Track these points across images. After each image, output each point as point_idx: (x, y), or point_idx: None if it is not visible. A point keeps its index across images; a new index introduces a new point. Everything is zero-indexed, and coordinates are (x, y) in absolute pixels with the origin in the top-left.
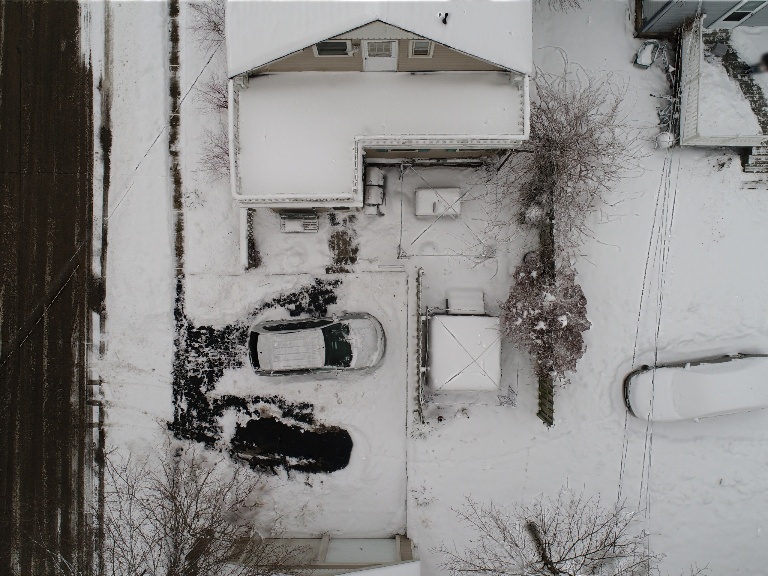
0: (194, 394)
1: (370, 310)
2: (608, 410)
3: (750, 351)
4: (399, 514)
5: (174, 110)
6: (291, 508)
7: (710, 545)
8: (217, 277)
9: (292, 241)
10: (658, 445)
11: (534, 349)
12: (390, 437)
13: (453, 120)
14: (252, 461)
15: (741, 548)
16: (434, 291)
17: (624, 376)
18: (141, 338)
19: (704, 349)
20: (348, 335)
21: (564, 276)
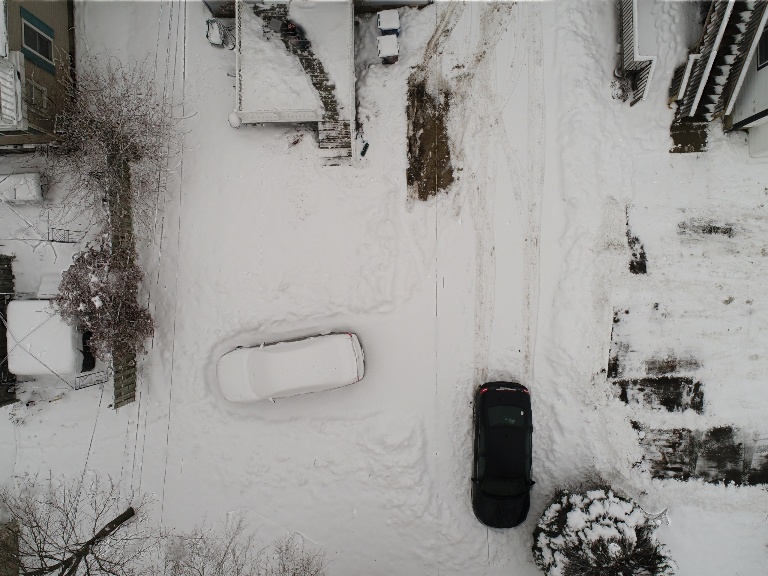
0: None
1: None
2: (202, 392)
3: (343, 330)
4: None
5: None
6: None
7: (306, 527)
8: None
9: None
10: (253, 427)
11: None
12: (2, 424)
13: None
14: None
15: (338, 530)
16: (30, 277)
17: None
18: None
19: (297, 329)
20: None
21: None
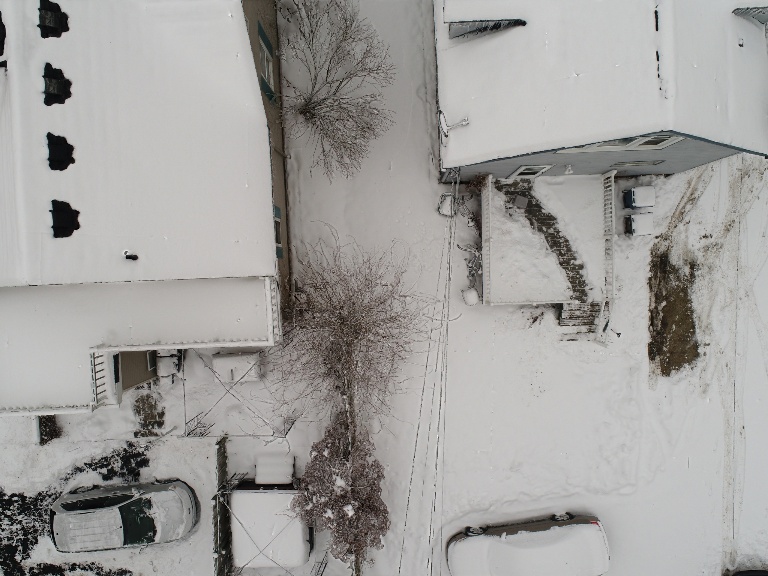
0: (9, 563)
1: (181, 475)
2: None
3: (578, 510)
4: None
5: None
6: None
7: None
8: (21, 447)
9: None
10: None
11: None
12: None
13: (203, 319)
14: None
15: None
16: (243, 456)
17: (447, 539)
18: None
19: (529, 509)
20: (150, 509)
21: None
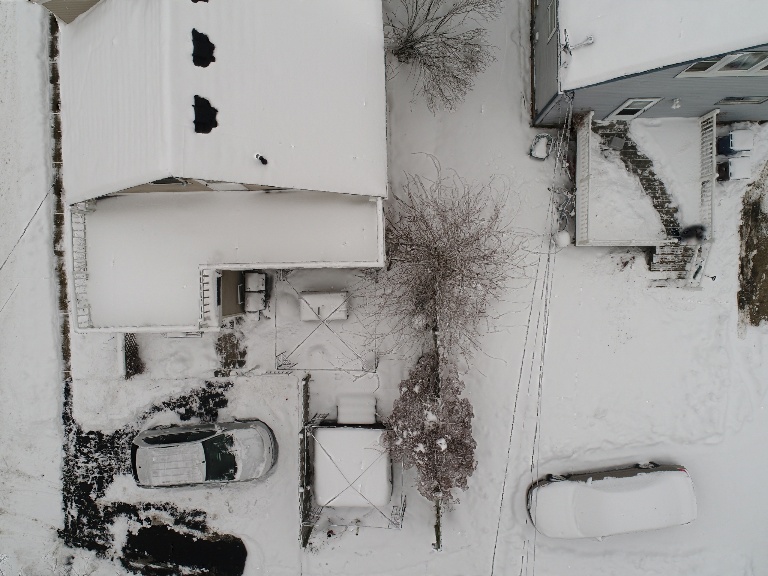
0: (84, 501)
1: (260, 415)
2: (510, 523)
3: (662, 460)
4: None
5: (58, 208)
6: None
7: None
8: (102, 383)
9: (177, 345)
10: (564, 560)
11: (419, 468)
12: (284, 547)
13: (309, 242)
14: (144, 570)
15: None
16: (324, 397)
17: (527, 486)
18: (29, 444)
19: (612, 457)
20: (232, 446)
21: (451, 389)
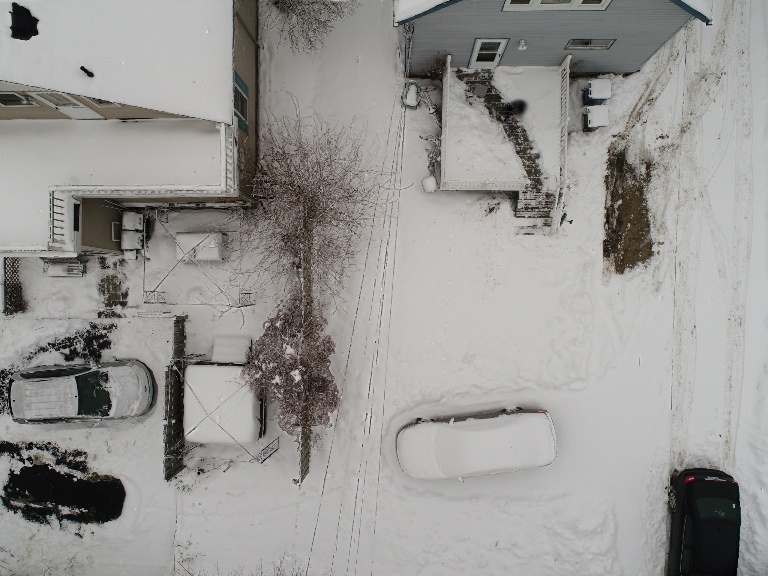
0: None
1: (141, 356)
2: (378, 465)
3: (529, 405)
4: (170, 568)
5: None
6: (60, 559)
7: None
8: None
9: (60, 285)
10: (431, 503)
11: None
12: (161, 488)
13: (161, 169)
14: (24, 509)
15: None
16: (202, 338)
17: (398, 429)
18: None
19: (480, 402)
20: (107, 383)
21: None
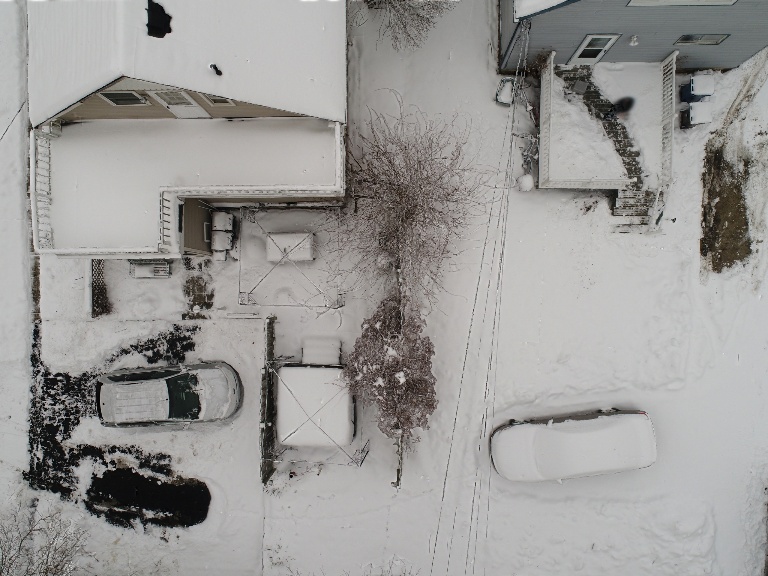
0: (50, 443)
1: (227, 358)
2: (472, 467)
3: (625, 406)
4: (257, 572)
5: None
6: (146, 564)
7: None
8: (70, 323)
9: (145, 286)
10: (526, 505)
11: (379, 405)
12: (248, 491)
13: (270, 169)
14: (108, 513)
15: None
16: (290, 339)
17: (490, 431)
18: None
19: (575, 403)
20: (196, 386)
21: None
